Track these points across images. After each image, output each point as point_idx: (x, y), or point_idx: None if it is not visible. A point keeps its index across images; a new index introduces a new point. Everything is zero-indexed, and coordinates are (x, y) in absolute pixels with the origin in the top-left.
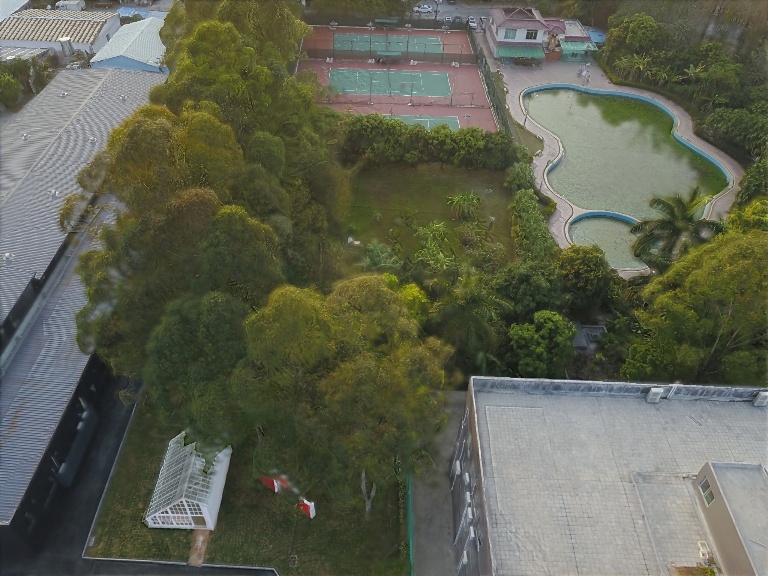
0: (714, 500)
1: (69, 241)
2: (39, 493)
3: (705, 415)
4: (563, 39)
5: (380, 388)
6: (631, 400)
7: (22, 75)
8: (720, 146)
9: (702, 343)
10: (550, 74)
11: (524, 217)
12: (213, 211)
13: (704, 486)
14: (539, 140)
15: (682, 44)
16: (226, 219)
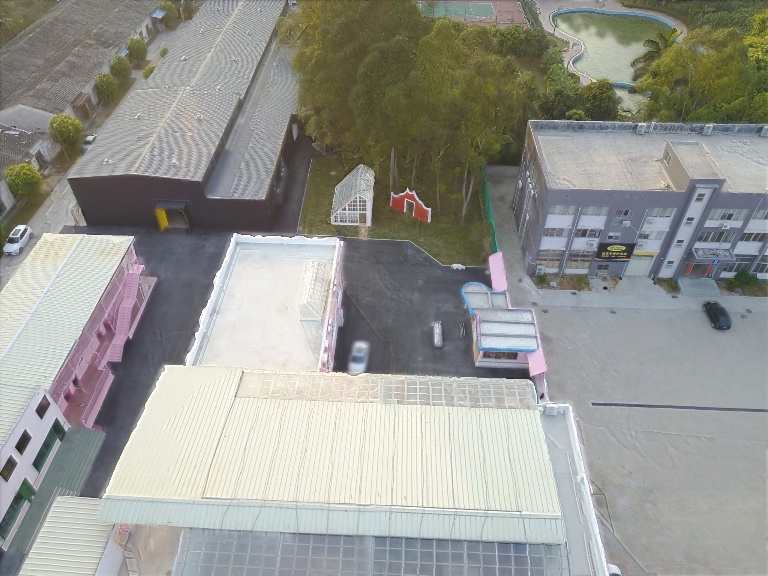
0: (671, 158)
1: None
2: None
3: (672, 139)
4: None
5: (488, 73)
6: (626, 134)
7: (176, 4)
8: None
9: (674, 115)
10: (574, 2)
11: (556, 78)
12: None
13: (666, 157)
14: (566, 42)
15: None
16: None
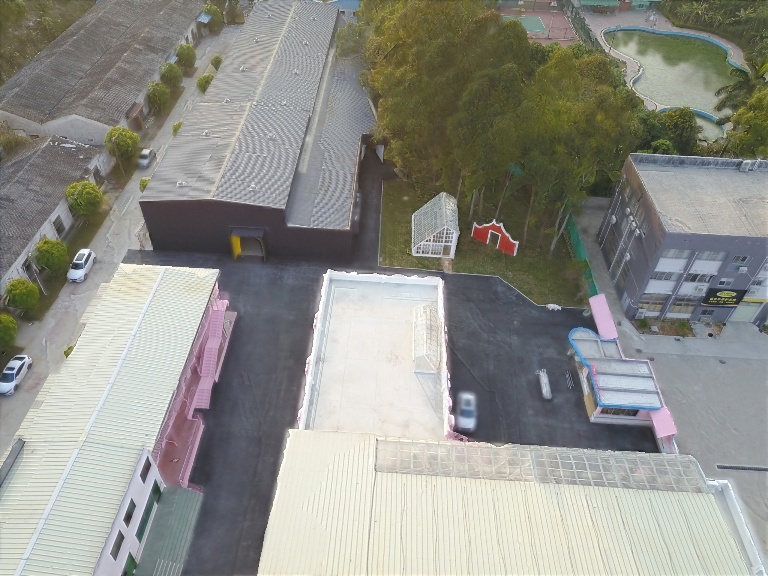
0: None
1: (315, 101)
2: None
3: None
4: None
5: (611, 107)
6: (729, 171)
7: (220, 8)
8: None
9: None
10: (623, 19)
11: None
12: (502, 22)
13: None
14: (622, 62)
15: None
16: (513, 24)
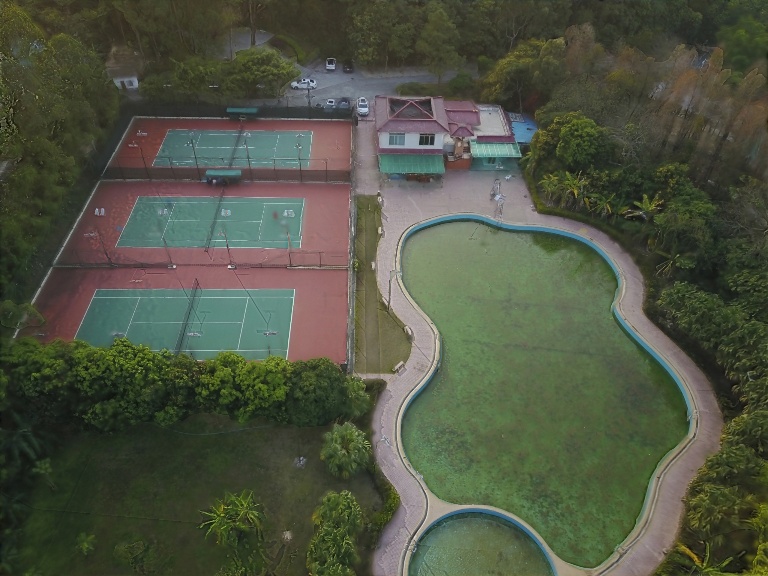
0: None
1: None
2: None
3: None
4: (475, 139)
5: None
6: None
7: None
8: (681, 342)
9: None
10: (452, 196)
11: None
12: None
13: None
14: (406, 336)
15: (632, 162)
16: None
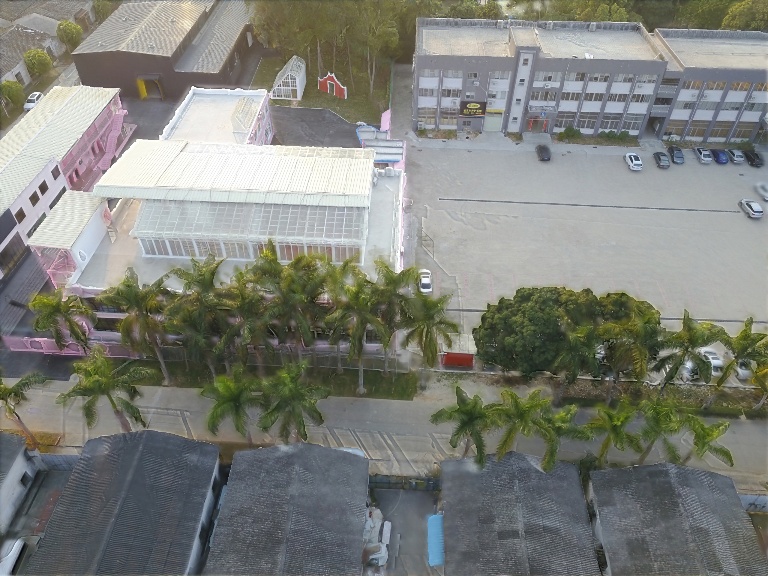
0: None
1: (216, 5)
2: (224, 76)
3: None
4: None
5: None
6: None
7: None
8: None
9: (534, 20)
10: None
11: None
12: None
13: (509, 39)
14: None
15: None
16: None
